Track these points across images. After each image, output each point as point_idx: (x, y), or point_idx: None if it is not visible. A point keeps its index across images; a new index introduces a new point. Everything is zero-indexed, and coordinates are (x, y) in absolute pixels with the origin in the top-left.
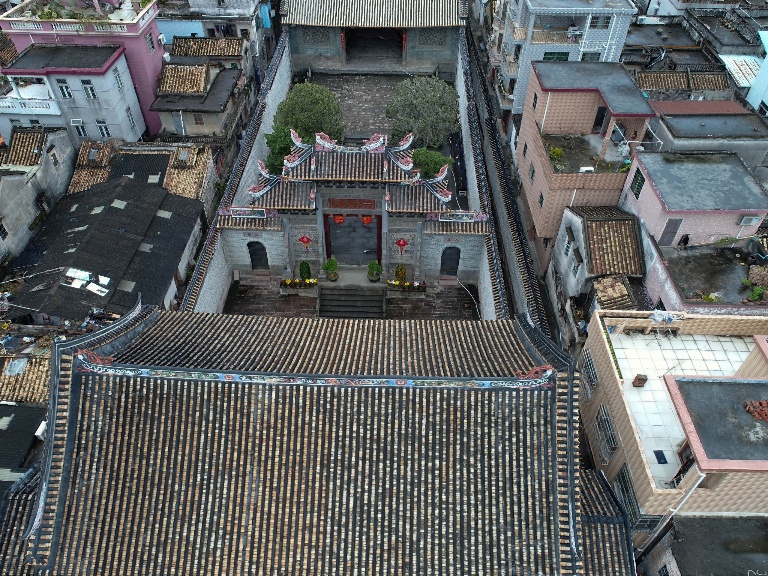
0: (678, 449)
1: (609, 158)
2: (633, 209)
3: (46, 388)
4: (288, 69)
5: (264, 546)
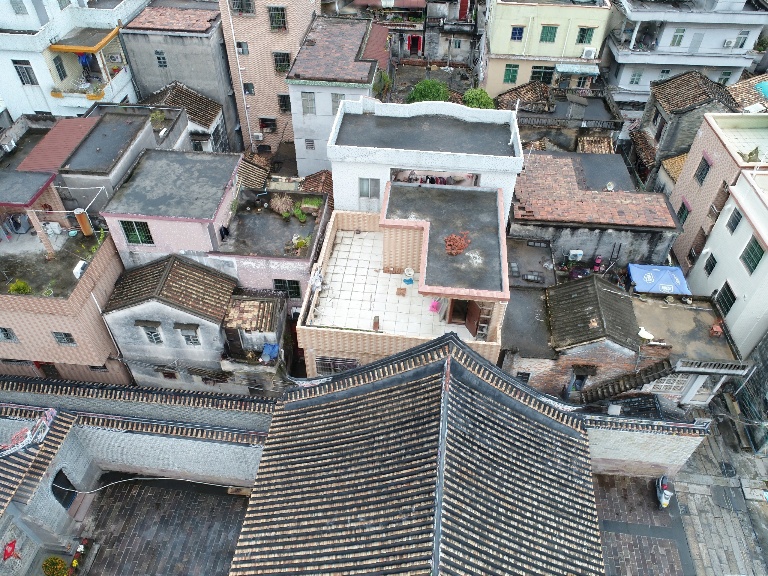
0: (444, 322)
1: (55, 246)
2: (157, 254)
3: None
4: None
5: None
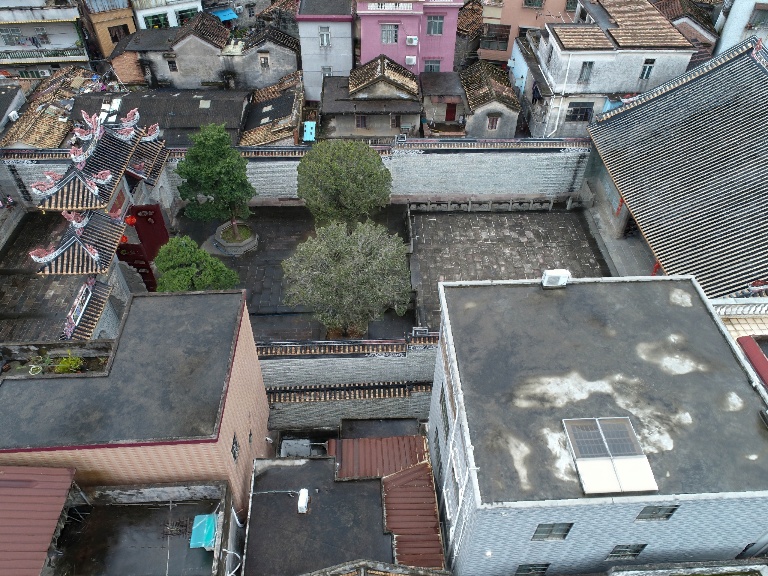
0: None
1: None
2: None
3: None
4: (555, 180)
5: None
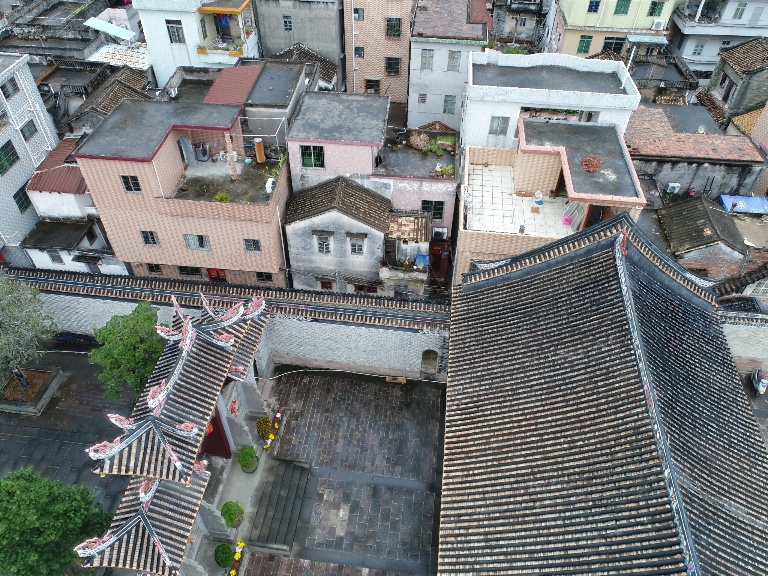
0: None
1: None
2: (325, 177)
3: None
4: None
5: (767, 513)
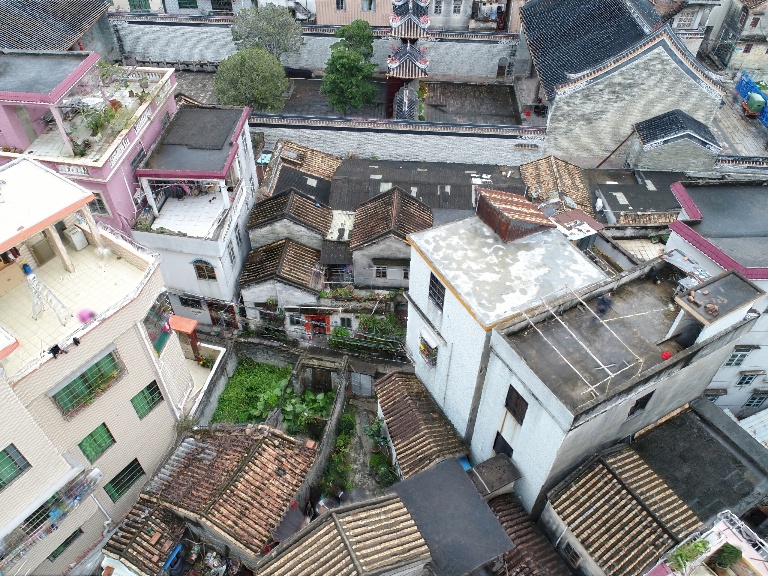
0: None
1: None
2: None
3: (580, 191)
4: None
5: None
